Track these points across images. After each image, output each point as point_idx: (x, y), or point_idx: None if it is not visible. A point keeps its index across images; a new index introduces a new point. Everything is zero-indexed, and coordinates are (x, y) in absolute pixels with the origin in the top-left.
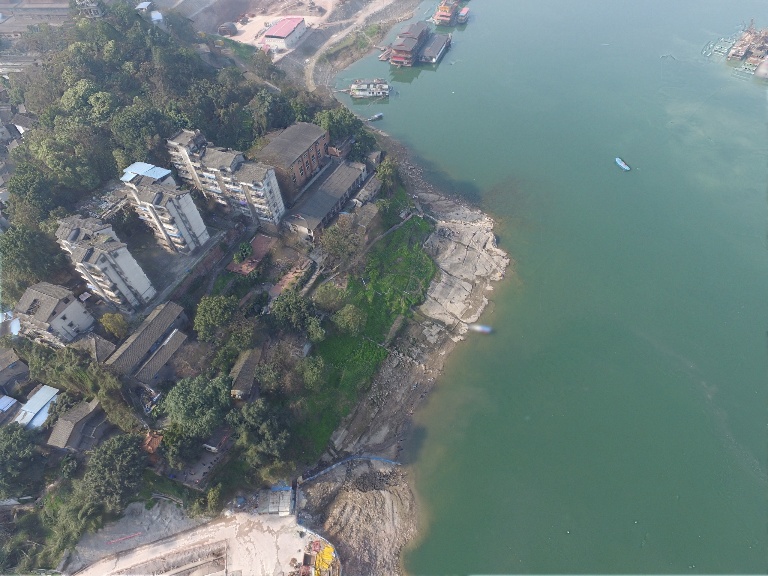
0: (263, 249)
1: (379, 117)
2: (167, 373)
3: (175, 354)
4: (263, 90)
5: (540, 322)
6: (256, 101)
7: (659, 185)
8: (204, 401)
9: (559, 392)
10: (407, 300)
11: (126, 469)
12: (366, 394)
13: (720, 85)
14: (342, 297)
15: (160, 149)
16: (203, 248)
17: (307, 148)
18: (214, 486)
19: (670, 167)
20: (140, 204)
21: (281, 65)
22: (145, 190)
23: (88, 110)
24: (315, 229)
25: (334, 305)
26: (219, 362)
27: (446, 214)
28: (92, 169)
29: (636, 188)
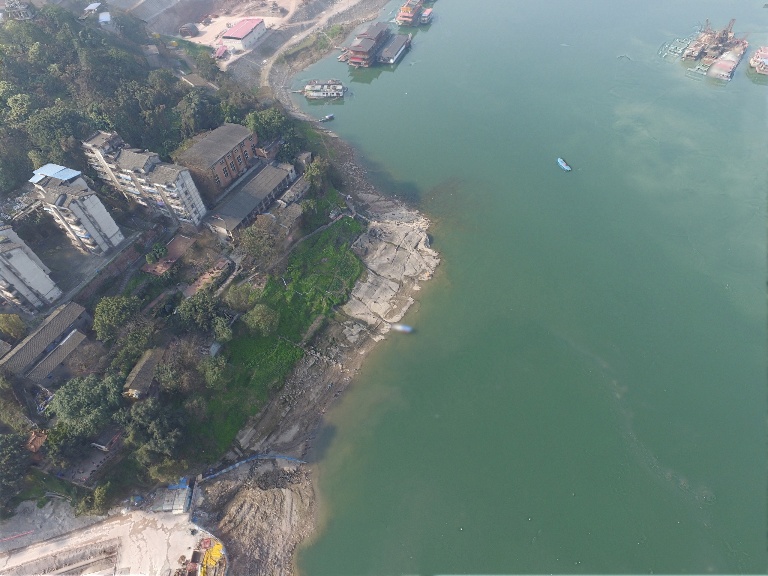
0: (180, 250)
1: (330, 118)
2: (64, 373)
3: (71, 354)
4: (192, 92)
5: (462, 321)
6: (183, 103)
7: (598, 185)
8: (91, 400)
9: (471, 391)
10: (329, 300)
11: (5, 468)
12: (278, 393)
13: (671, 85)
14: (258, 297)
15: (77, 151)
16: (116, 249)
17: (230, 149)
18: (104, 484)
19: (610, 167)
20: (46, 205)
21: (236, 66)
22: (50, 191)
23: (6, 112)
24: (234, 230)
25: (250, 305)
26: (119, 362)
27: (382, 214)
28: (7, 171)
29: (575, 188)
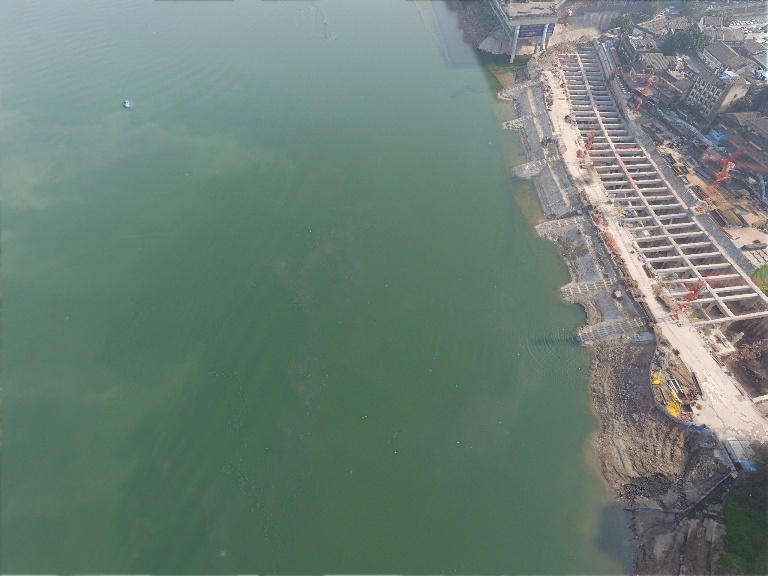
0: None
1: None
2: None
3: None
4: None
5: None
6: None
7: None
8: None
9: None
10: None
11: None
12: None
13: None
14: None
15: None
16: None
17: None
18: None
19: None
20: None
21: None
22: None
23: None
24: None
25: None
26: None
27: None
28: None
29: None
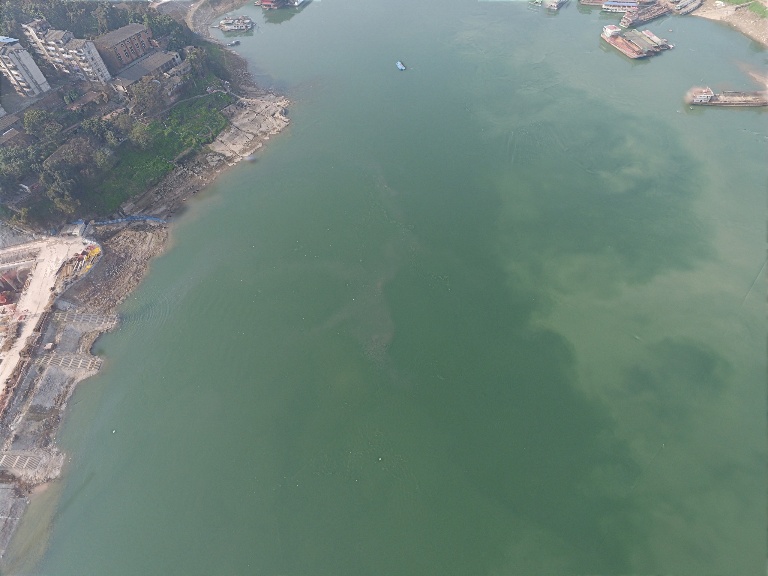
0: (90, 99)
1: (237, 43)
2: None
3: (9, 139)
4: (105, 1)
5: (292, 154)
6: (99, 8)
7: (422, 78)
8: (18, 156)
9: (284, 187)
10: (198, 139)
11: None
12: (153, 187)
13: (510, 14)
14: None
15: (19, 32)
16: (45, 94)
17: (129, 37)
18: None
19: (435, 67)
20: None
21: (166, 6)
22: None
23: None
24: (128, 87)
25: None
26: None
27: (254, 97)
28: None
29: (405, 81)
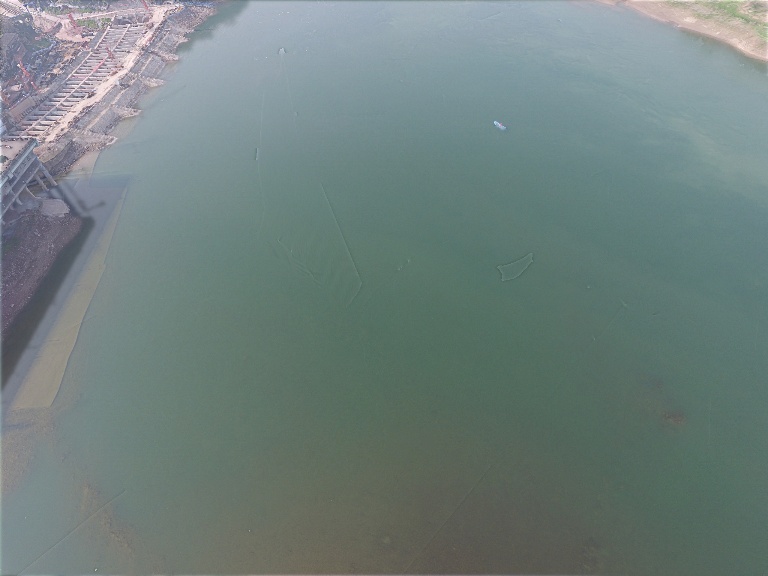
0: None
1: None
2: None
3: None
4: None
5: None
6: None
7: None
8: None
9: None
10: None
11: None
12: None
13: None
14: None
15: None
16: None
17: None
18: None
19: None
20: None
21: None
22: None
23: None
24: None
25: None
26: None
27: None
28: None
29: None
